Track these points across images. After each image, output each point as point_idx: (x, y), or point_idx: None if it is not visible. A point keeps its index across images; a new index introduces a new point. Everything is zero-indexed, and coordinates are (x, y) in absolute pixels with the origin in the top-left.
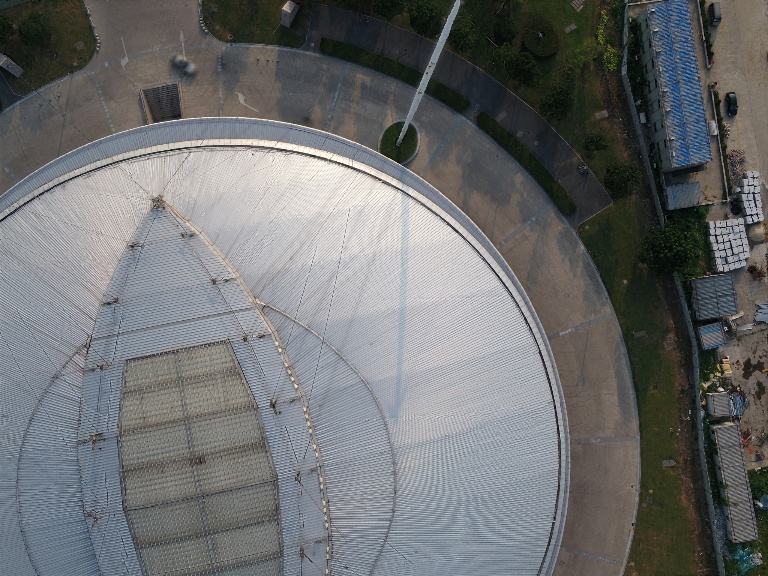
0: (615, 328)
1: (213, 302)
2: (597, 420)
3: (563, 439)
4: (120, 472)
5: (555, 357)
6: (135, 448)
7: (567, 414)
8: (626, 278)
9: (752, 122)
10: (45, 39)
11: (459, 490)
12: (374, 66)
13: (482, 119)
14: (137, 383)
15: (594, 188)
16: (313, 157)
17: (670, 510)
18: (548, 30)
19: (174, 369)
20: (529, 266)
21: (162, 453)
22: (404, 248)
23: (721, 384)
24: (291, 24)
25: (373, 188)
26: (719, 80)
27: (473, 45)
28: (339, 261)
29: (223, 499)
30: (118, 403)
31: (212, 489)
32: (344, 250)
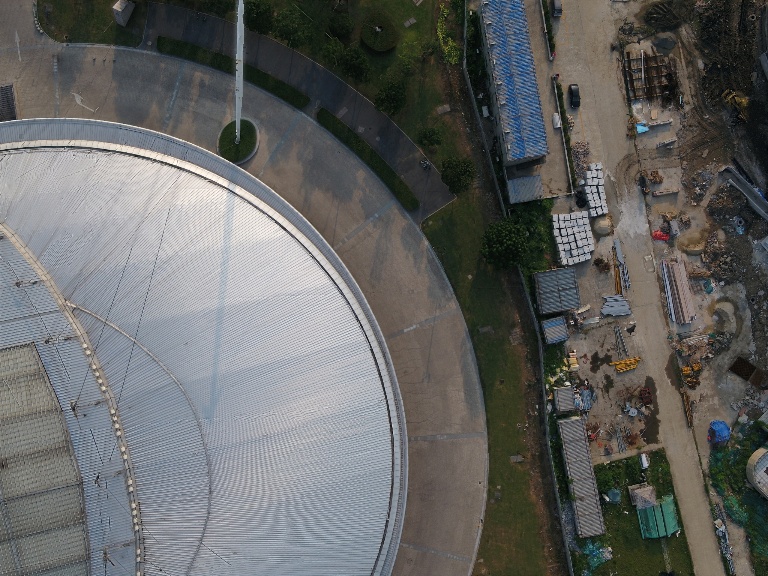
0: (460, 324)
1: (19, 305)
2: (443, 417)
3: (397, 436)
4: None
5: (400, 354)
6: None
7: (412, 411)
8: (471, 273)
9: (596, 114)
10: None
11: (280, 490)
12: (212, 64)
13: (322, 115)
14: None
15: (437, 183)
16: (136, 157)
17: (518, 506)
18: (386, 24)
19: None
20: (372, 263)
21: None
22: (226, 247)
23: (568, 378)
24: (127, 23)
25: (197, 187)
26: (562, 72)
27: (305, 41)
28: (155, 261)
29: (26, 503)
30: None
31: (15, 494)
32: (161, 250)
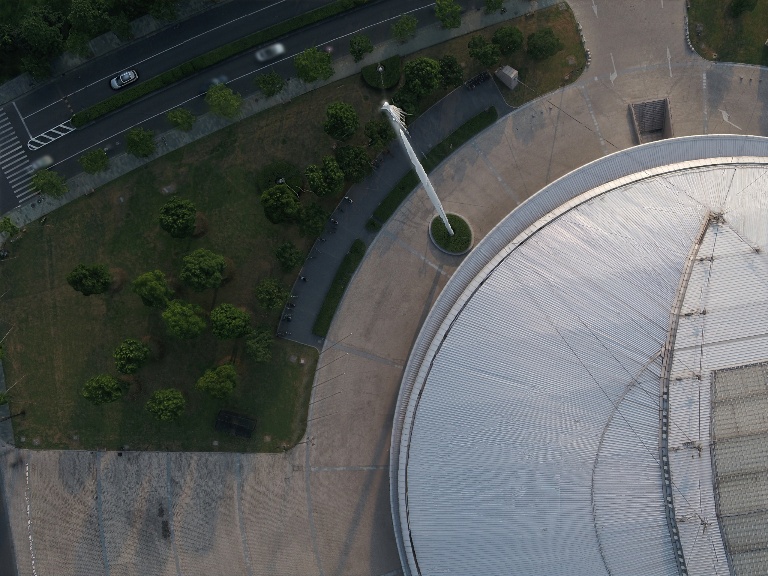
0: None
1: None
2: None
3: None
4: (714, 479)
5: None
6: (729, 457)
7: None
8: None
9: None
10: (553, 53)
11: None
12: None
13: None
14: (727, 393)
15: None
16: None
17: None
18: None
19: (763, 381)
20: None
21: (756, 462)
22: None
23: None
24: None
25: None
26: None
27: None
28: None
29: None
30: (709, 412)
31: None
32: None
